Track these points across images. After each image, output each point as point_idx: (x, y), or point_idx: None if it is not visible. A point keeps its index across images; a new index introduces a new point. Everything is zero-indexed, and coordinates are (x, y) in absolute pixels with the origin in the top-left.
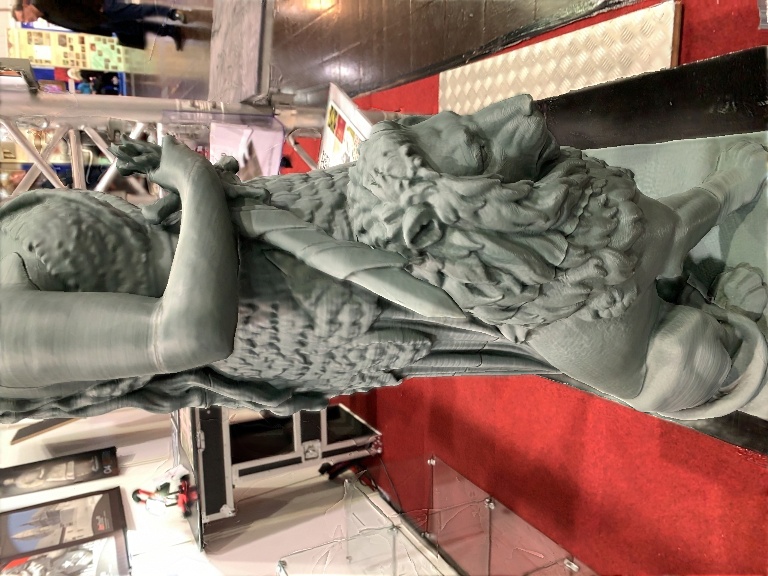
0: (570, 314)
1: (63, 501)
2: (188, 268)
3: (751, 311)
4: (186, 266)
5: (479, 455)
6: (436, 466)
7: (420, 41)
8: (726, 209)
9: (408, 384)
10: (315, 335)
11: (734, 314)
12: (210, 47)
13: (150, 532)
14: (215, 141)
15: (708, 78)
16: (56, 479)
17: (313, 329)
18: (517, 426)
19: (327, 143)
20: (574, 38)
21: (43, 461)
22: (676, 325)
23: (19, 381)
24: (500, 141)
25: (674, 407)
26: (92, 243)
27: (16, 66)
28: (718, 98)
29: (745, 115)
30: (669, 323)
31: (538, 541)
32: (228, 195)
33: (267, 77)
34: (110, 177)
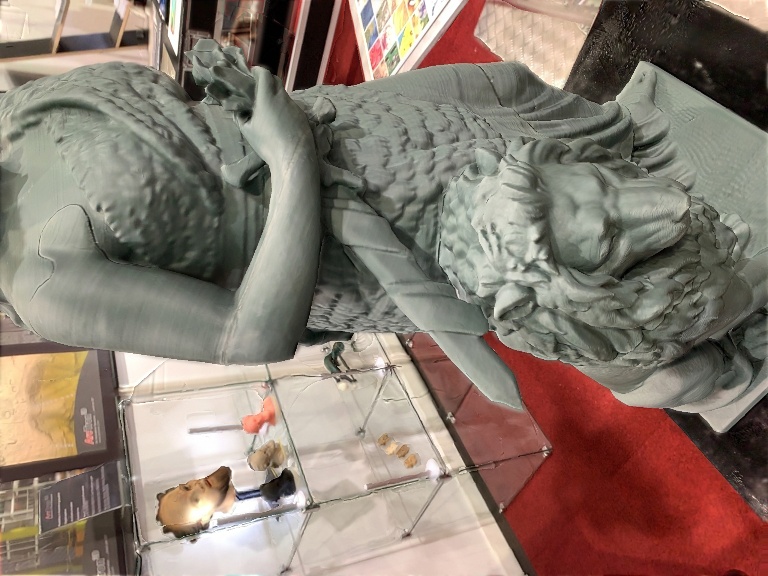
0: None
1: None
2: (271, 289)
3: (756, 357)
4: (269, 286)
5: None
6: None
7: None
8: None
9: None
10: (367, 318)
11: (741, 357)
12: None
13: None
14: None
15: None
16: None
17: (367, 315)
18: None
19: None
20: None
21: None
22: (688, 368)
23: None
24: (633, 235)
25: None
26: (165, 209)
27: None
28: None
29: None
30: (683, 363)
31: None
32: (323, 183)
33: None
34: None
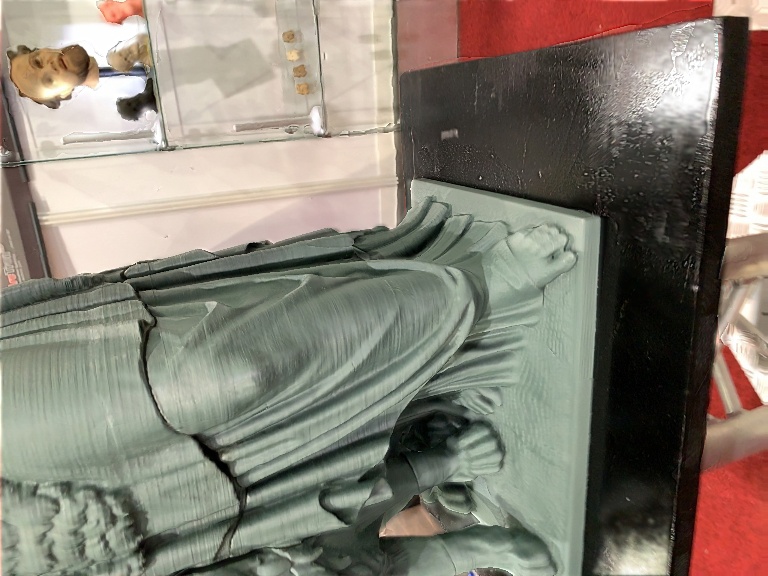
0: None
1: None
2: None
3: None
4: None
5: None
6: None
7: None
8: None
9: None
10: None
11: None
12: None
13: None
14: None
15: (644, 564)
16: None
17: None
18: None
19: None
20: None
21: None
22: None
23: None
24: None
25: None
26: None
27: None
28: (620, 558)
29: (600, 569)
30: None
31: None
32: None
33: None
34: None
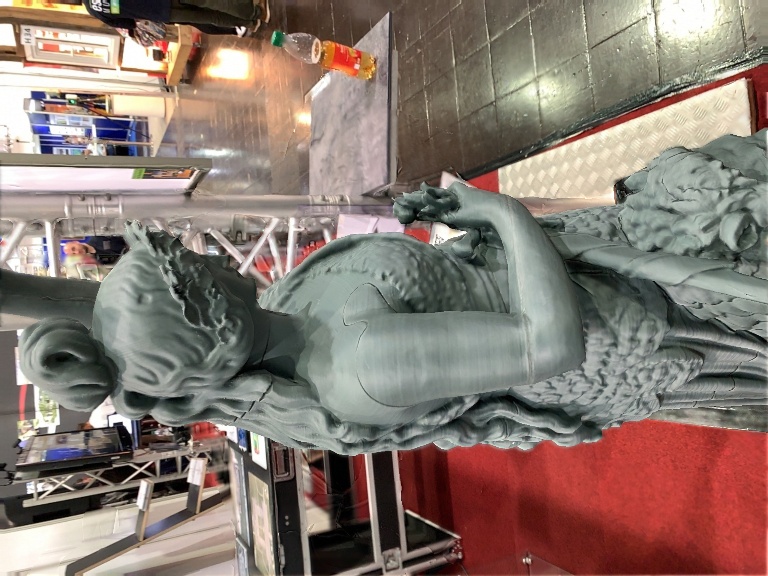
0: None
1: None
2: (543, 281)
3: None
4: (540, 279)
5: (585, 546)
6: (532, 565)
7: (472, 144)
8: None
9: (489, 478)
10: (617, 353)
11: None
12: (309, 155)
13: None
14: (343, 231)
15: None
16: None
17: (616, 347)
18: (628, 507)
19: (441, 227)
20: (643, 122)
21: None
22: None
23: (403, 397)
24: None
25: None
26: (429, 272)
27: (200, 165)
28: None
29: None
30: None
31: None
32: None
33: (395, 168)
34: (244, 272)
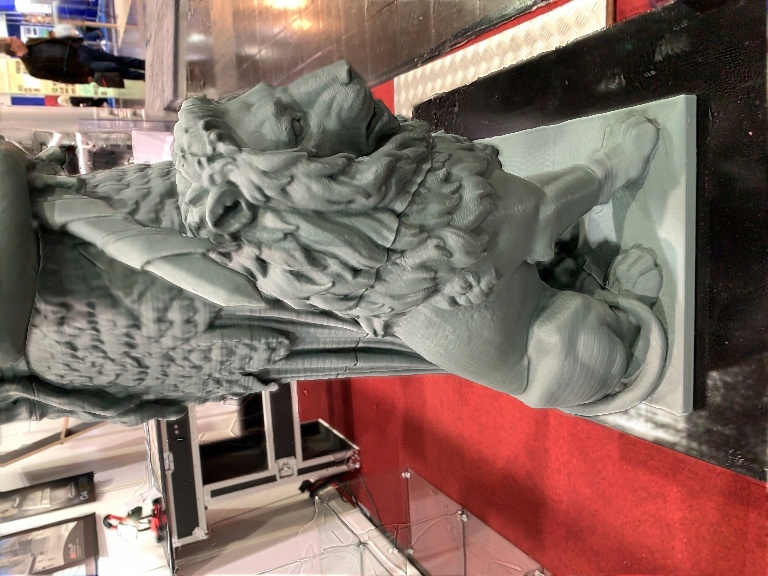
0: (420, 302)
1: (36, 530)
2: None
3: (644, 295)
4: None
5: (450, 466)
6: (411, 479)
7: (376, 47)
8: (609, 186)
9: (381, 396)
10: (143, 335)
11: (625, 298)
12: (145, 57)
13: (122, 558)
14: (137, 149)
15: (598, 52)
16: (31, 507)
17: (140, 329)
18: (484, 434)
19: None
20: (515, 34)
21: (19, 489)
22: (554, 311)
23: None
24: (318, 113)
25: (566, 401)
26: None
27: None
28: (608, 72)
29: (634, 88)
30: (547, 310)
31: (512, 553)
32: (33, 185)
33: (184, 81)
34: None
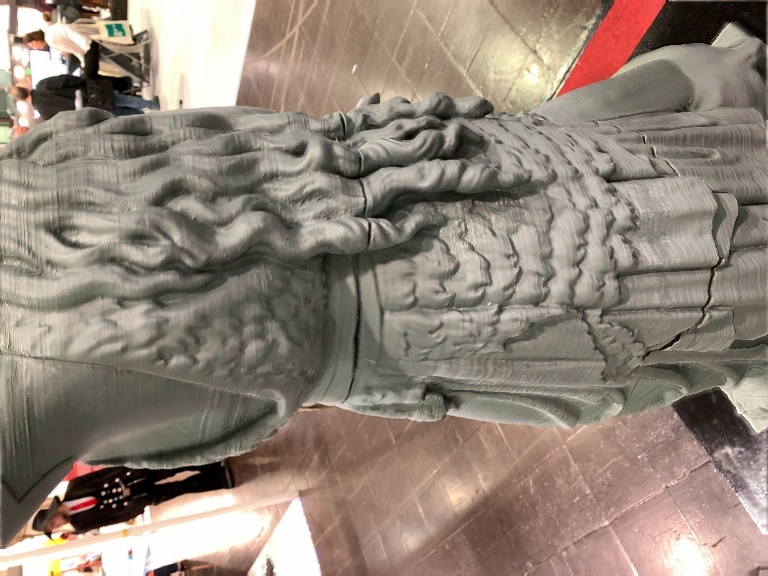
0: None
1: None
2: None
3: None
4: None
5: None
6: None
7: None
8: None
9: None
10: None
11: None
12: None
13: None
14: None
15: None
16: None
17: None
18: None
19: None
20: None
21: None
22: None
23: None
24: None
25: None
26: None
27: None
28: None
29: None
30: None
31: None
32: None
33: None
34: None
